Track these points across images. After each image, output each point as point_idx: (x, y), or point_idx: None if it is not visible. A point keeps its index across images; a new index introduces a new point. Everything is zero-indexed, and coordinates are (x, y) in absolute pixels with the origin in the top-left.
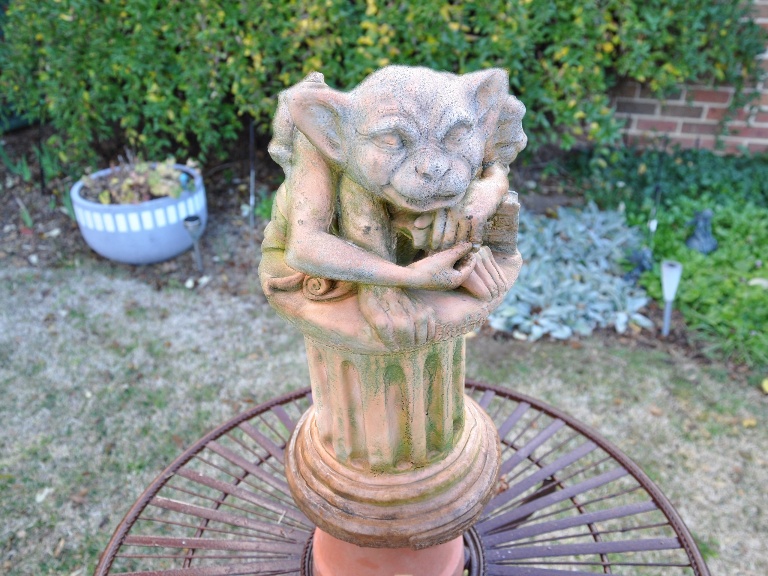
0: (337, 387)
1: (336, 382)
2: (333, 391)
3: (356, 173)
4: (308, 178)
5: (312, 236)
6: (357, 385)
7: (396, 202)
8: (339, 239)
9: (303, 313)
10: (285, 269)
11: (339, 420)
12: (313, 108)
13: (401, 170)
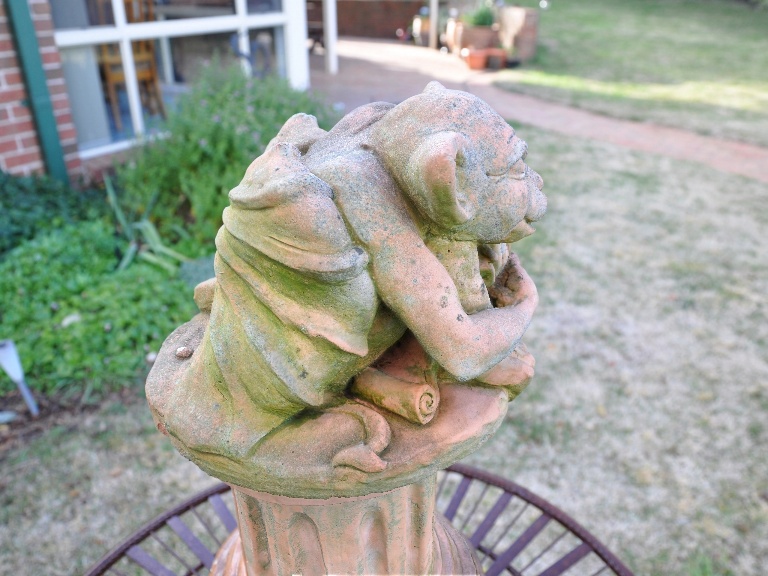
0: (403, 525)
1: (402, 520)
2: (397, 536)
3: (491, 224)
4: (430, 265)
5: (481, 323)
6: (407, 506)
7: (523, 234)
8: (489, 310)
9: (446, 439)
10: (339, 433)
11: (402, 565)
12: (455, 166)
13: (534, 195)
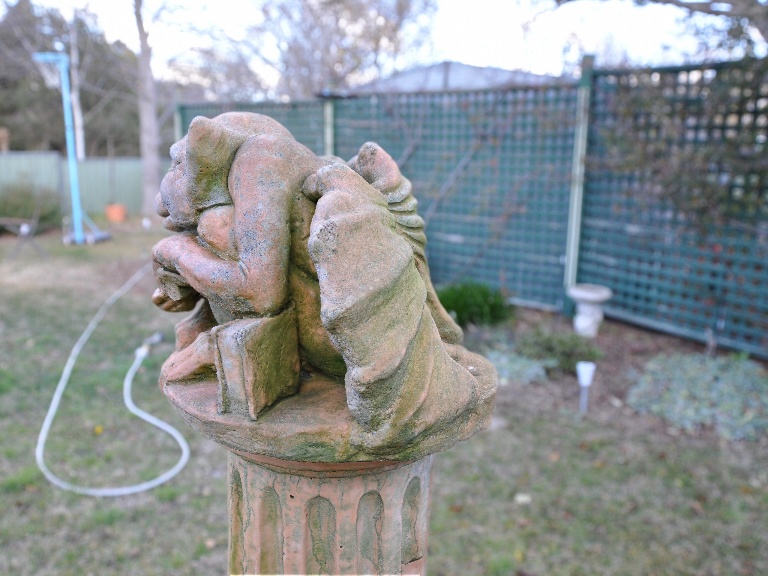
0: None
1: None
2: None
3: None
4: None
5: None
6: None
7: None
8: None
9: None
10: None
11: None
12: None
13: None
